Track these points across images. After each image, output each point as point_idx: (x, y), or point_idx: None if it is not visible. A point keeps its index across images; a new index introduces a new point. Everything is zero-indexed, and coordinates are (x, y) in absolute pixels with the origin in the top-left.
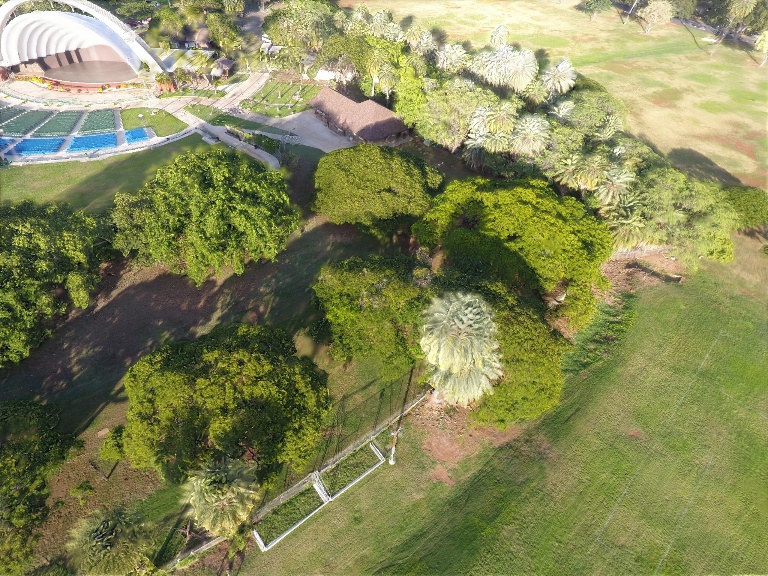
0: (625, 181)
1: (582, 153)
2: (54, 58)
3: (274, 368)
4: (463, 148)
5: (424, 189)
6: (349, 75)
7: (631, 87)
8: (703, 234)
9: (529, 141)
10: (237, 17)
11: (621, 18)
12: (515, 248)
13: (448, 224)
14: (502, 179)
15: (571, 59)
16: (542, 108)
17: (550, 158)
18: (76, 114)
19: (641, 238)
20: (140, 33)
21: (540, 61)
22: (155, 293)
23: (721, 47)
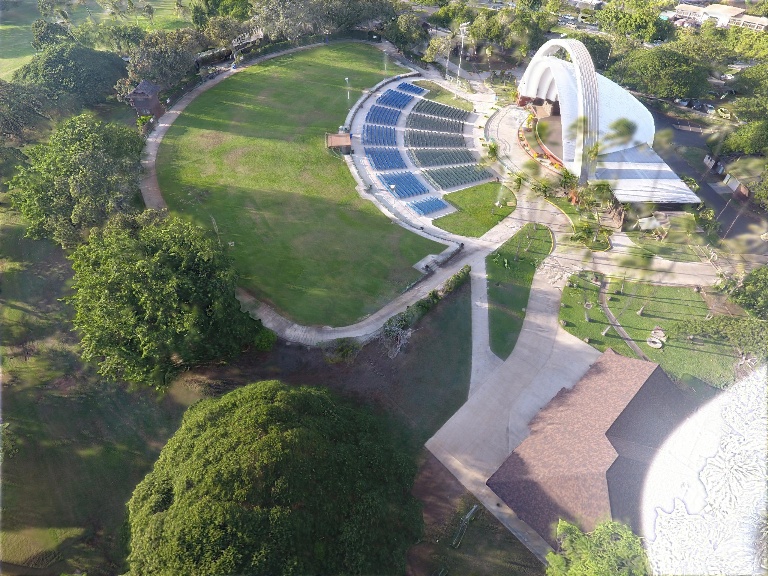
0: None
1: None
2: None
3: None
4: None
5: None
6: None
7: None
8: None
9: None
10: None
11: None
12: None
13: None
14: None
15: None
16: None
17: None
18: (466, 158)
19: None
20: None
21: None
22: None
23: None
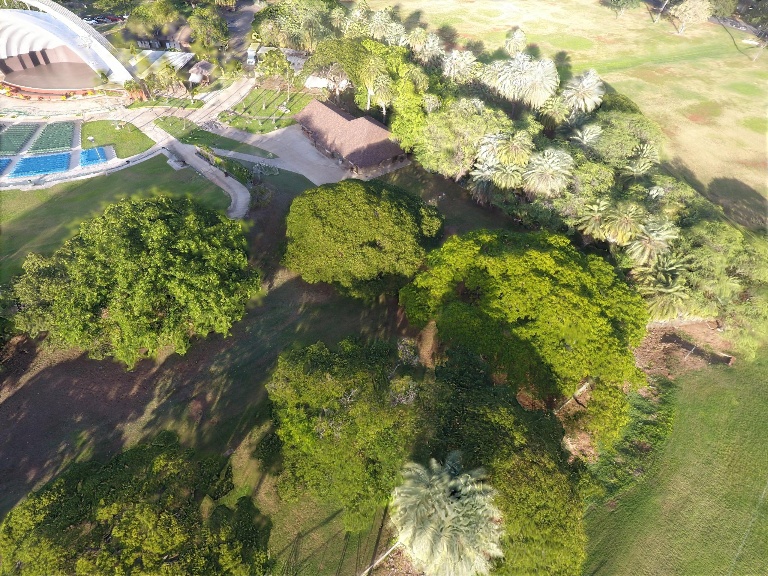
0: (666, 239)
1: (612, 198)
2: (16, 60)
3: (190, 535)
4: (468, 178)
5: (417, 240)
6: (344, 83)
7: (664, 99)
8: (765, 313)
9: (547, 178)
10: (228, 11)
11: (651, 15)
12: (526, 335)
13: (443, 295)
14: (513, 217)
15: (595, 64)
16: (562, 128)
17: (572, 203)
18: (30, 128)
19: (684, 311)
20: (120, 29)
21: (560, 66)
22: (76, 378)
23: (764, 51)
